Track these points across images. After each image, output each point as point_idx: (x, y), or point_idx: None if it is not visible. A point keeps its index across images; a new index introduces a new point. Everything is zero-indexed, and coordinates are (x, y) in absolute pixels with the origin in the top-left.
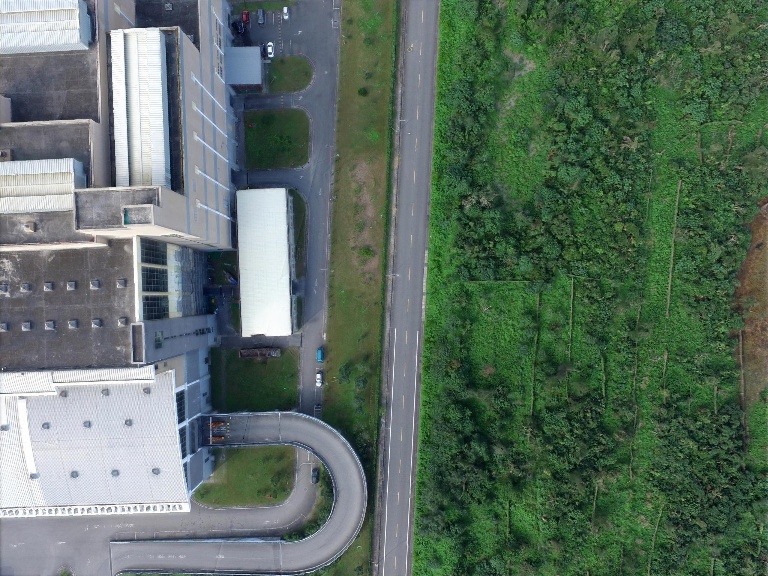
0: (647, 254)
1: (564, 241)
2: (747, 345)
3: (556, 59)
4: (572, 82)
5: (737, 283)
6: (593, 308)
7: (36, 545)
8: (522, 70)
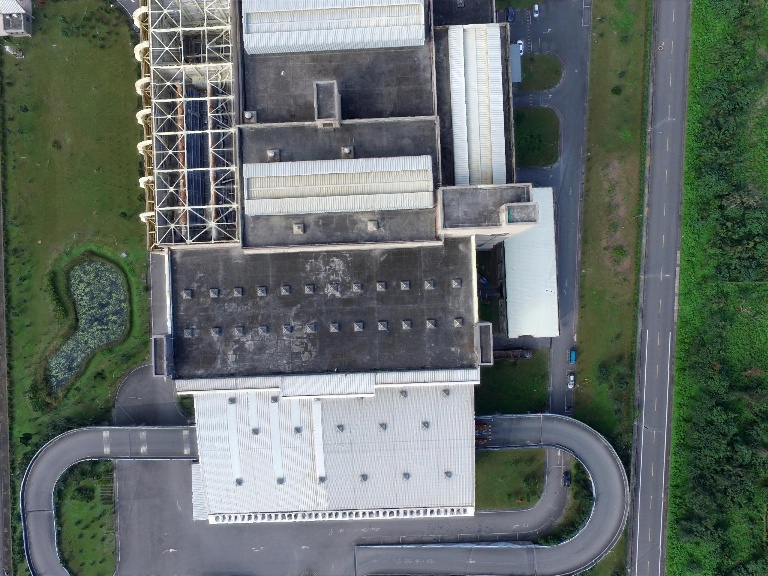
0: None
1: None
2: None
3: None
4: None
5: None
6: None
7: (279, 549)
8: None
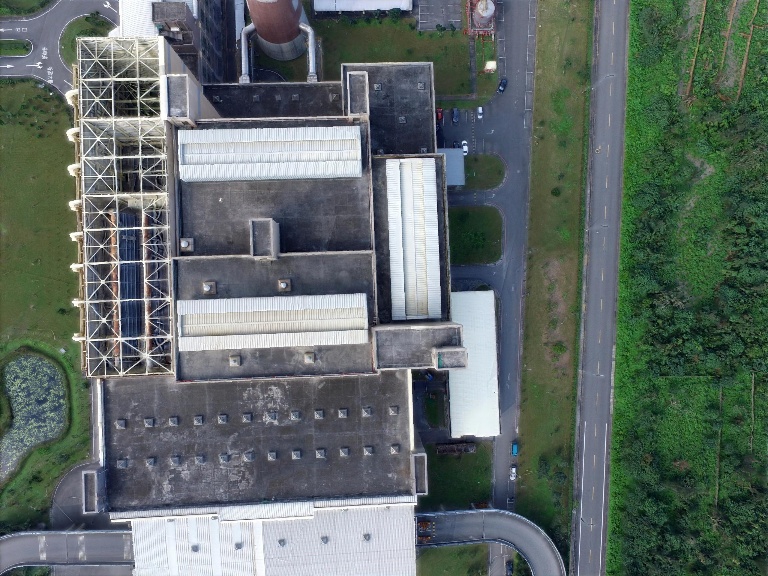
0: None
1: (746, 338)
2: None
3: (739, 167)
4: (753, 189)
5: None
6: None
7: None
8: (702, 174)
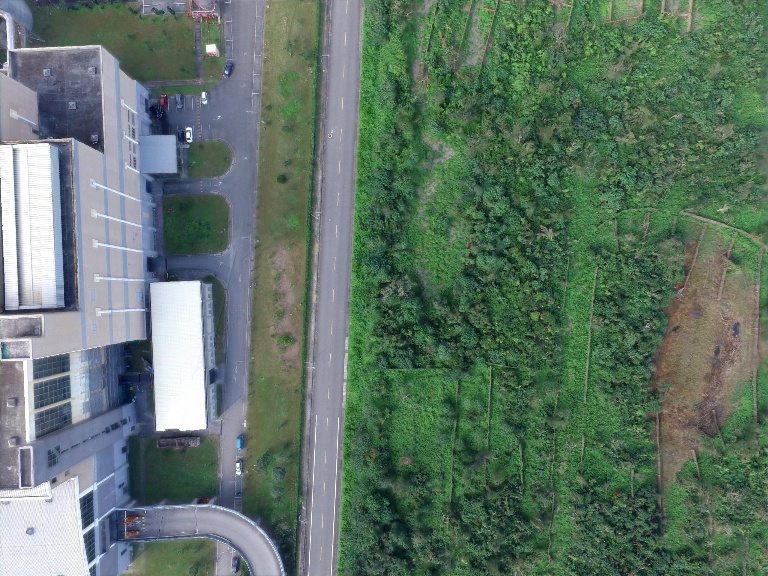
0: (565, 340)
1: (482, 329)
2: (664, 426)
3: (473, 149)
4: (489, 172)
5: (653, 368)
6: (511, 396)
7: None
8: (442, 157)
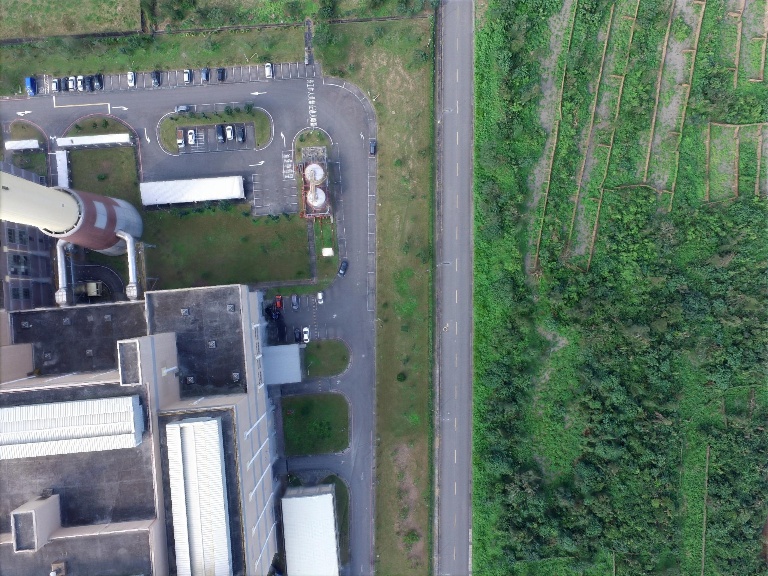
0: (681, 520)
1: (604, 518)
2: None
3: (589, 342)
4: (605, 363)
5: (764, 540)
6: None
7: None
8: (555, 346)
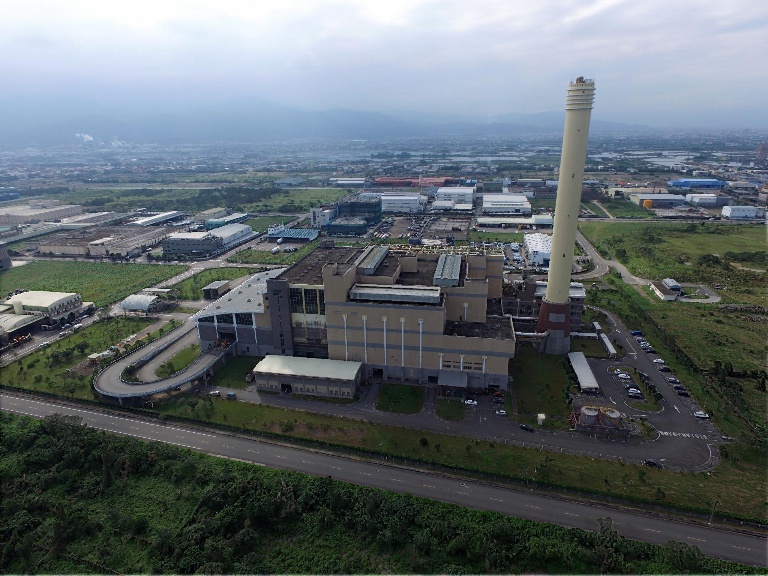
0: None
1: None
2: None
3: None
4: None
5: None
6: None
7: None
8: None
